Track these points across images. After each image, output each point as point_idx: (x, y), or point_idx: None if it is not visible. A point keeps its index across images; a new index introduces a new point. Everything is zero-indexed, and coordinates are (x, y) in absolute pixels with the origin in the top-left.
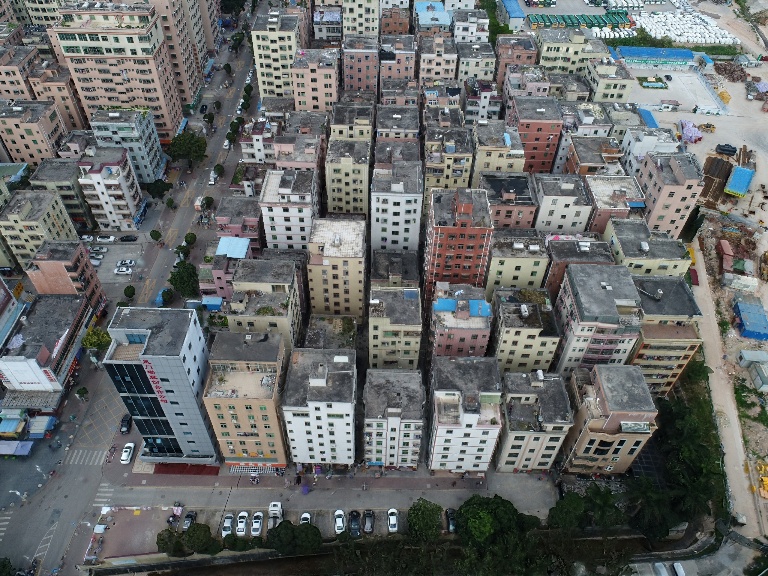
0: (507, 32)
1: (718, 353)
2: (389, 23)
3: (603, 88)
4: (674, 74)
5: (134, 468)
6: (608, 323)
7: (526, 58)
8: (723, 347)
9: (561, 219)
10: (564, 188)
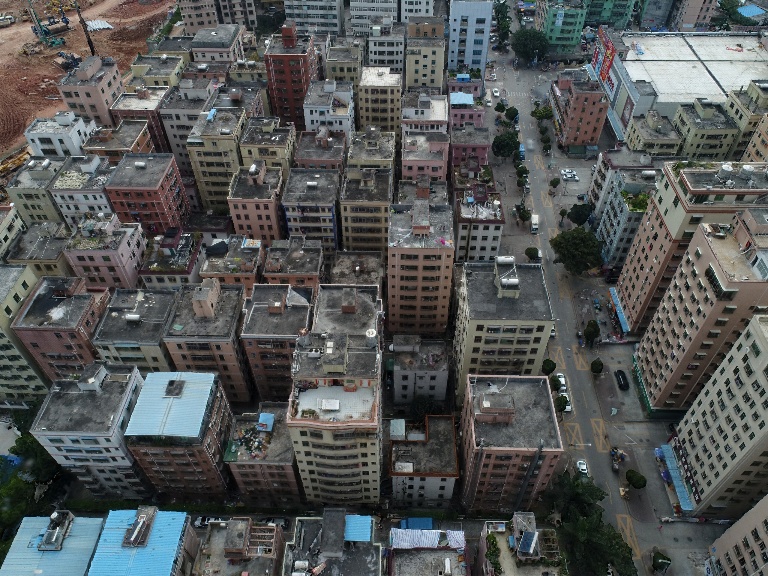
0: None
1: None
2: None
3: None
4: None
5: (489, 90)
6: None
7: None
8: None
9: None
10: None
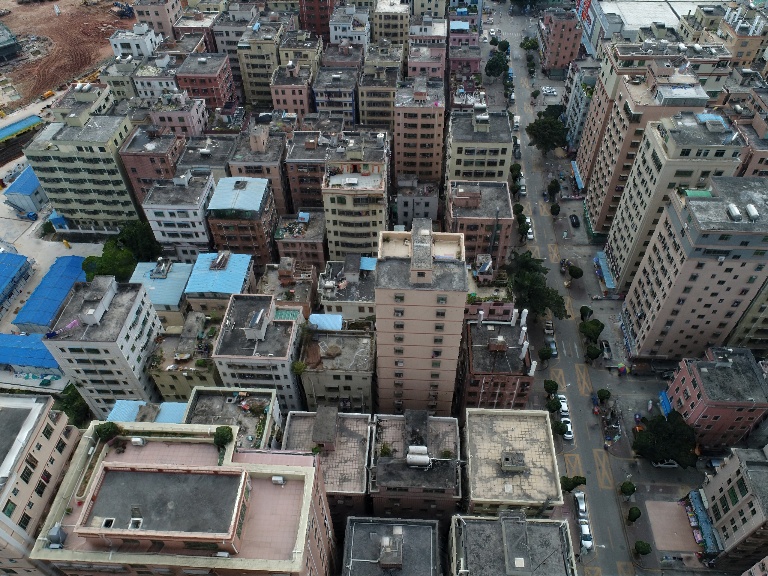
0: (93, 274)
1: None
2: None
3: None
4: None
5: (487, 31)
6: None
7: None
8: None
9: None
10: None
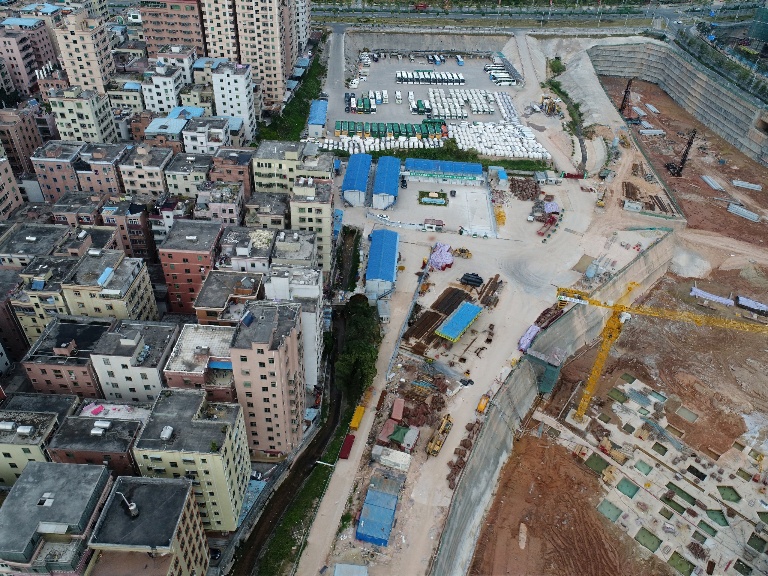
0: None
1: (318, 563)
2: (139, 128)
3: (297, 211)
4: (463, 189)
5: None
6: (11, 561)
7: (238, 173)
8: (330, 553)
9: (128, 381)
10: (124, 344)
